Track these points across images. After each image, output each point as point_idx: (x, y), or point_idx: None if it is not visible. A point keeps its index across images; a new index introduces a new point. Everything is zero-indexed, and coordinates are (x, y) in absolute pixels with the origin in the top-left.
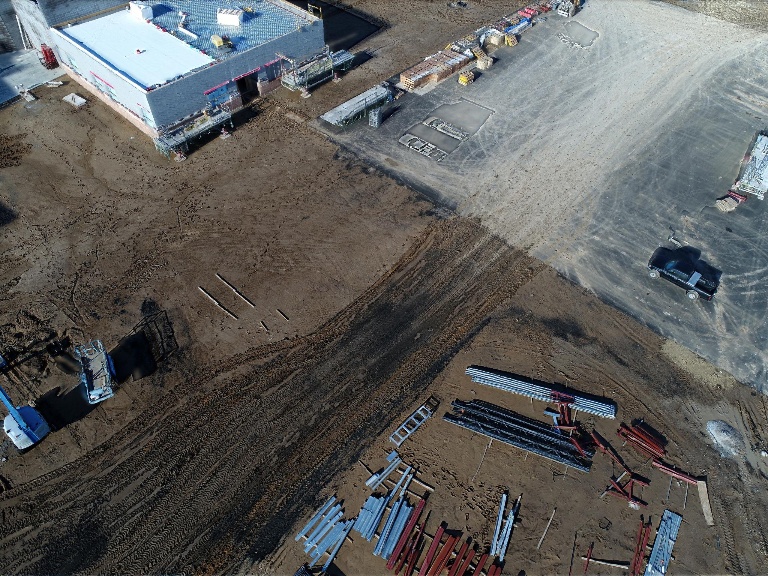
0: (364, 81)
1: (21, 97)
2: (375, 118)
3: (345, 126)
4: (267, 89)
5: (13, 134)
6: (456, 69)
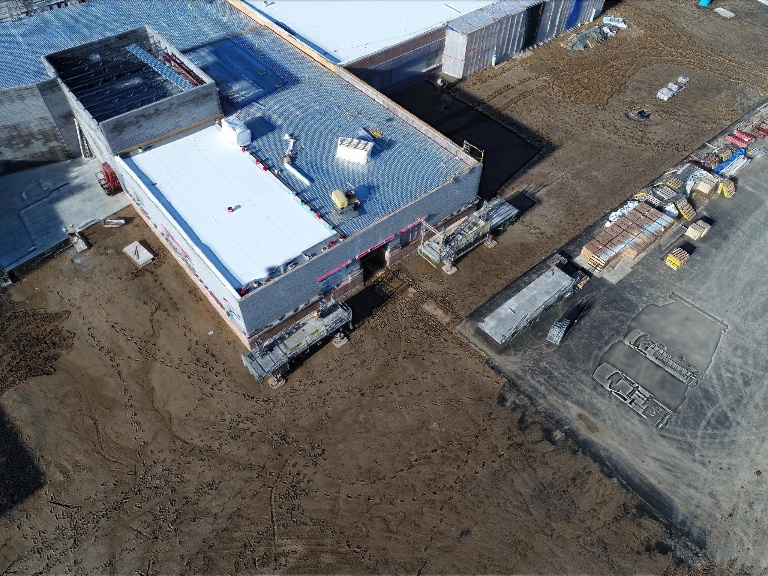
0: (529, 248)
1: (69, 242)
2: (558, 335)
3: (511, 339)
4: (397, 257)
5: (52, 310)
6: (658, 237)
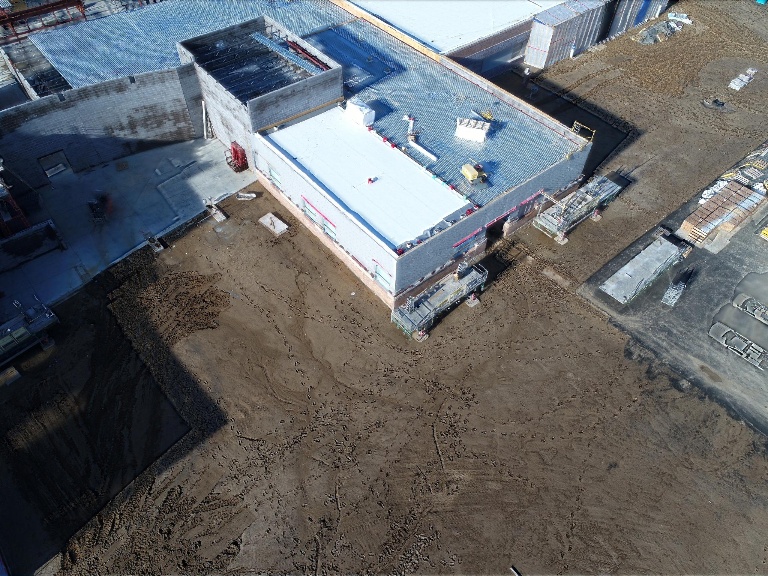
0: (631, 222)
1: (208, 213)
2: (674, 296)
3: (630, 301)
4: (513, 228)
5: (204, 273)
6: (750, 213)
